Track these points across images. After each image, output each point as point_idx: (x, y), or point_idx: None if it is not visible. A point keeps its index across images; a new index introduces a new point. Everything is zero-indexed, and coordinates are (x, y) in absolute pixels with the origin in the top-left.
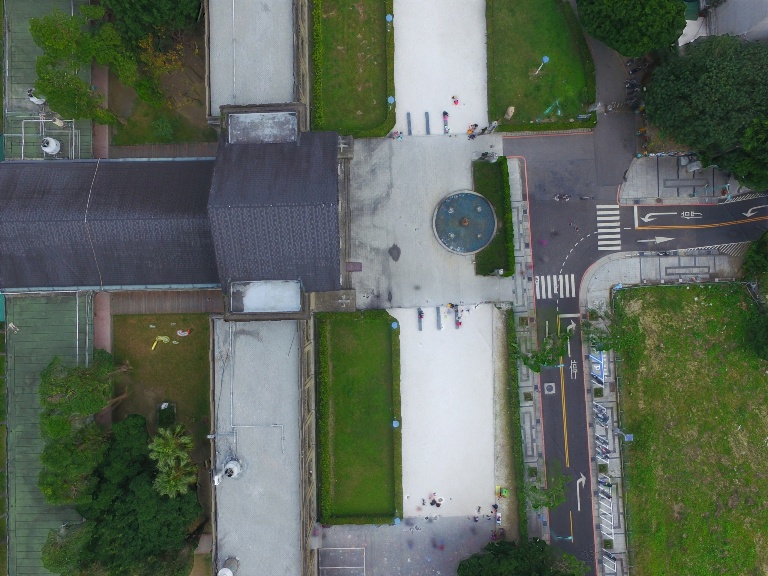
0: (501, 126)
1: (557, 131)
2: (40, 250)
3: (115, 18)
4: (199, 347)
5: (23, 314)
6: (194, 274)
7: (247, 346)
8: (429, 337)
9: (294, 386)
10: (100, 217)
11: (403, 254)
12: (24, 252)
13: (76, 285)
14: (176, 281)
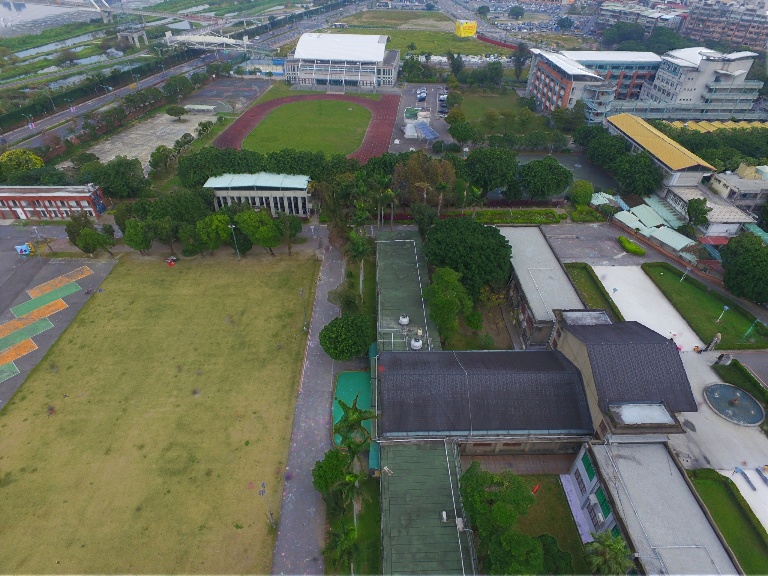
0: (717, 345)
1: (757, 350)
2: (426, 398)
3: (466, 279)
4: (547, 507)
5: (396, 459)
6: (549, 421)
7: (629, 468)
8: (767, 498)
9: (693, 505)
10: (477, 372)
11: (697, 427)
12: (413, 400)
13: (449, 430)
14: (534, 427)
